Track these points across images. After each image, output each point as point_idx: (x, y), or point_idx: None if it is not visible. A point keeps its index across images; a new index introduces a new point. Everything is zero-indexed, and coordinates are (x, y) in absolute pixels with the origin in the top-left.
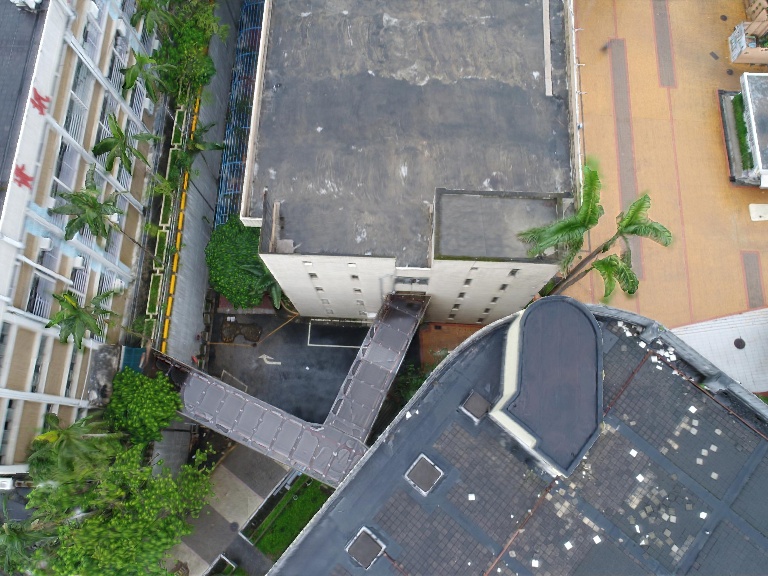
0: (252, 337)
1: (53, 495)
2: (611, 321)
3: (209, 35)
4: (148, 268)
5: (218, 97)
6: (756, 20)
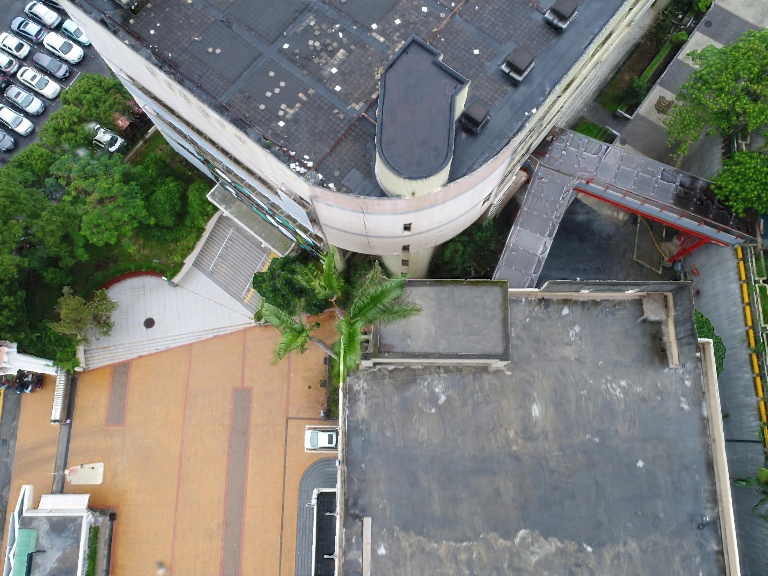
0: None
1: None
2: None
3: None
4: None
5: None
6: None
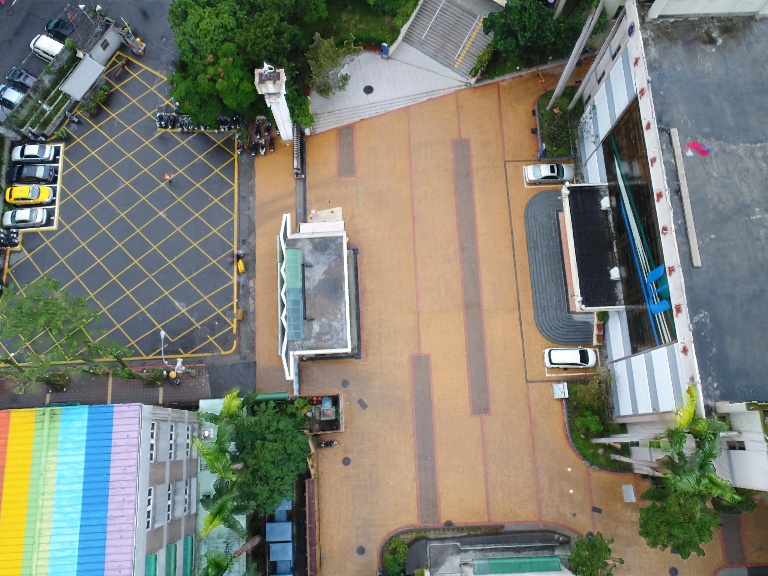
0: None
1: None
2: None
3: None
4: None
5: None
6: None
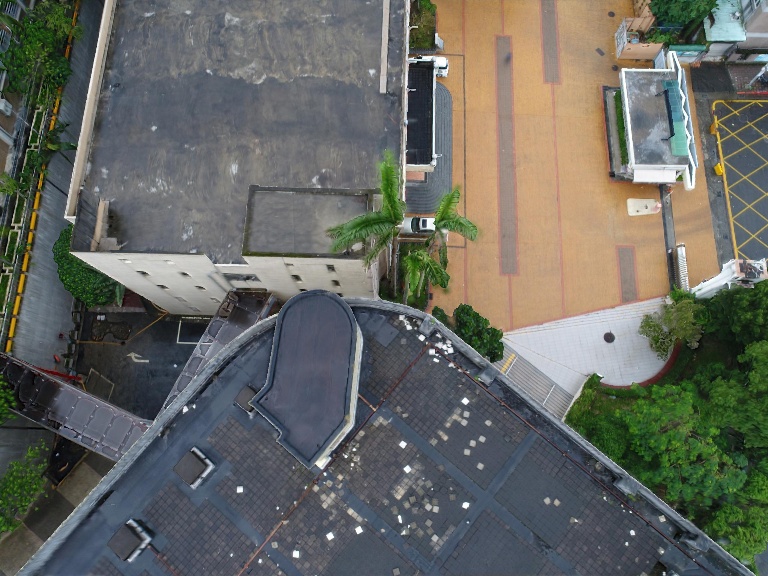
0: (122, 335)
1: None
2: (393, 315)
3: (61, 36)
4: (1, 268)
5: None
6: (641, 16)
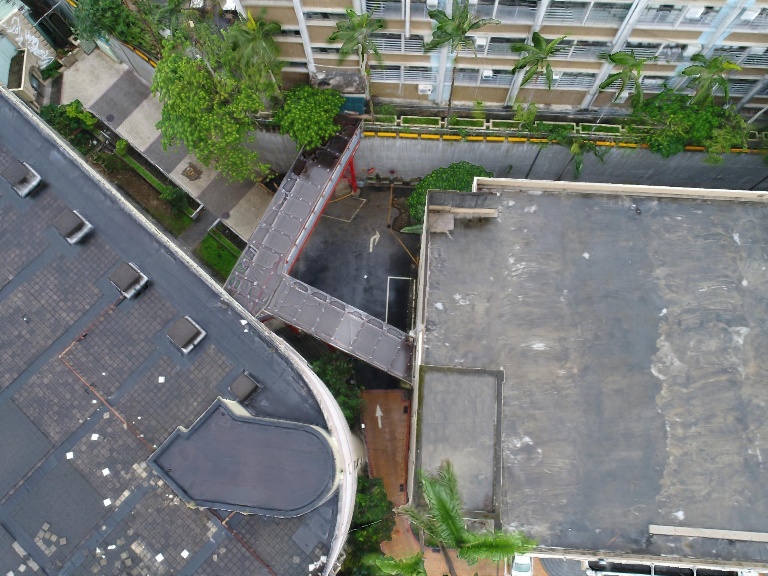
0: (397, 224)
1: (224, 44)
2: (327, 548)
3: (706, 143)
4: None
5: (652, 172)
6: None
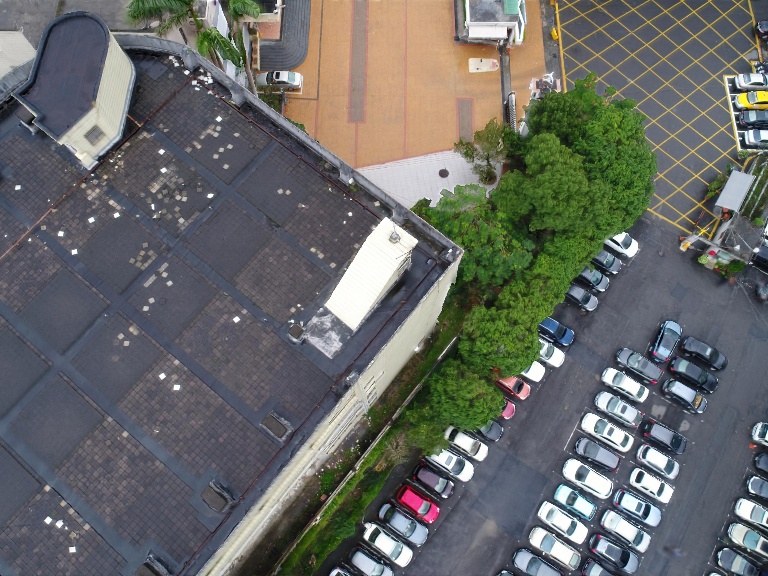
0: None
1: None
2: (164, 55)
3: None
4: None
5: None
6: None
